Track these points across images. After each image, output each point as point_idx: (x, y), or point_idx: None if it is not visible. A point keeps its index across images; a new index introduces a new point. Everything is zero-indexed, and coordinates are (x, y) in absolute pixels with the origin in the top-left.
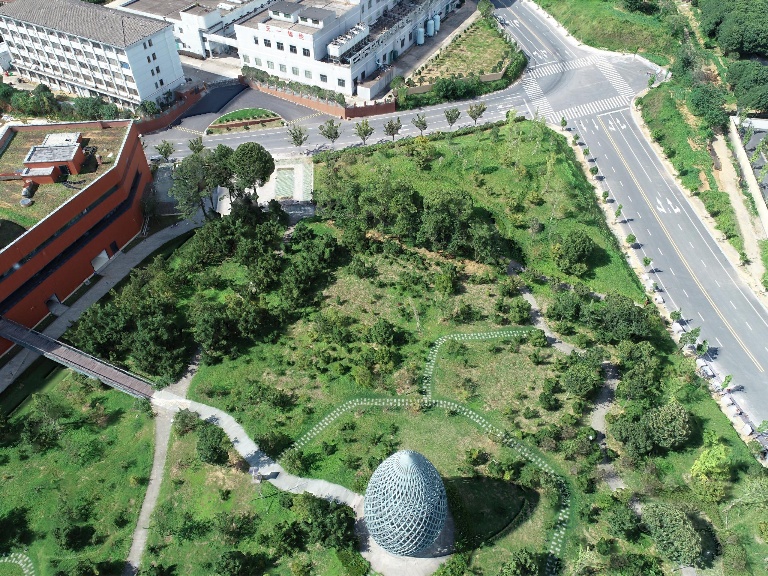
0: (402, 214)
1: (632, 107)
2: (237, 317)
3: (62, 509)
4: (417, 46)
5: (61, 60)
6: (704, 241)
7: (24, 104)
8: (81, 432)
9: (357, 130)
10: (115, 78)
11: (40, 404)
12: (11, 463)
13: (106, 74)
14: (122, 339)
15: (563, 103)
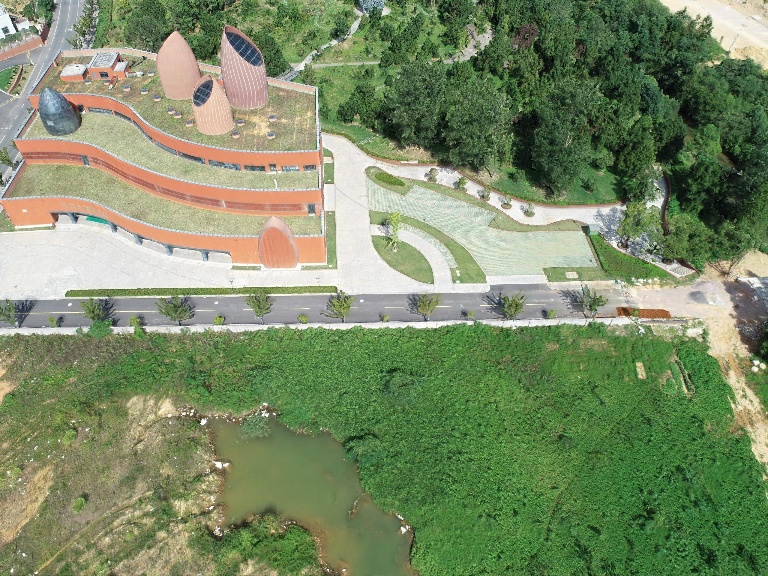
0: None
1: None
2: (264, 35)
3: None
4: None
5: None
6: None
7: None
8: None
9: (83, 26)
10: None
11: None
12: None
13: None
14: None
15: None
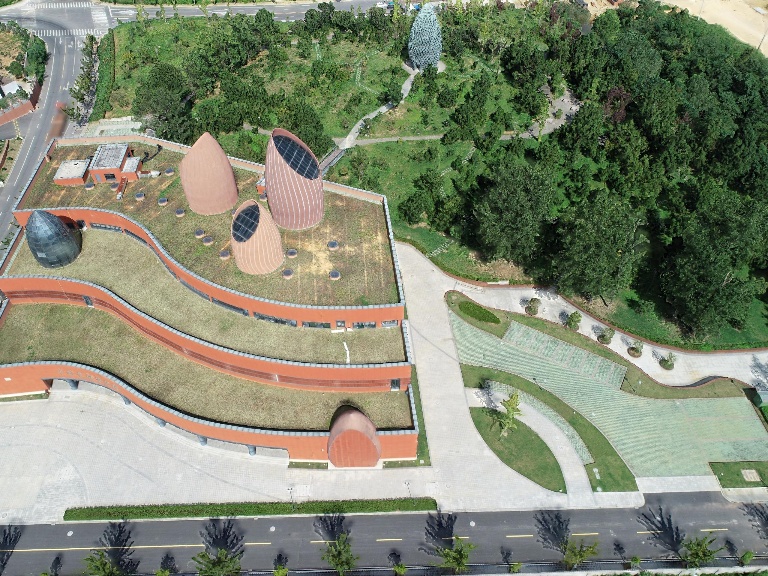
0: (237, 43)
1: (109, 5)
2: (301, 104)
3: (419, 153)
4: None
5: None
6: (254, 7)
7: None
8: None
9: None
10: None
11: None
12: None
13: None
14: None
15: (85, 25)
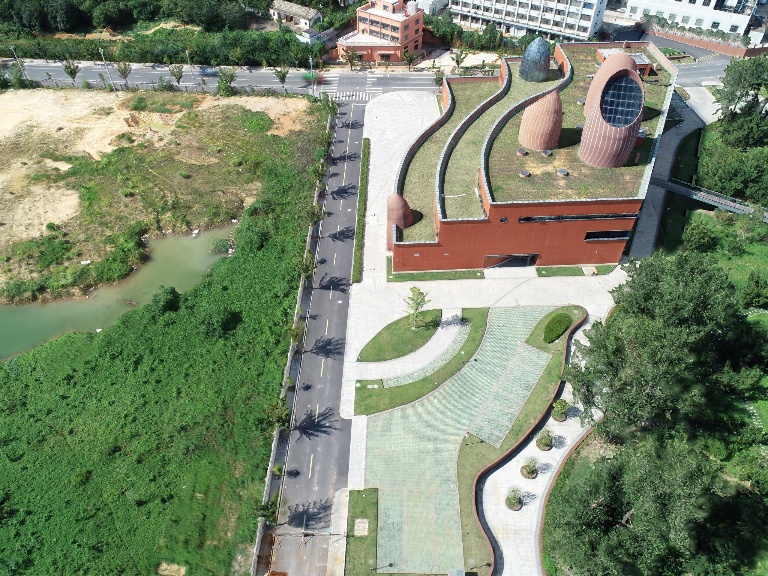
0: None
1: None
2: None
3: None
4: (759, 5)
5: (510, 4)
6: None
7: (478, 40)
8: (757, 245)
9: None
10: (568, 18)
11: (763, 214)
12: (721, 261)
13: (559, 15)
14: (749, 188)
15: None
